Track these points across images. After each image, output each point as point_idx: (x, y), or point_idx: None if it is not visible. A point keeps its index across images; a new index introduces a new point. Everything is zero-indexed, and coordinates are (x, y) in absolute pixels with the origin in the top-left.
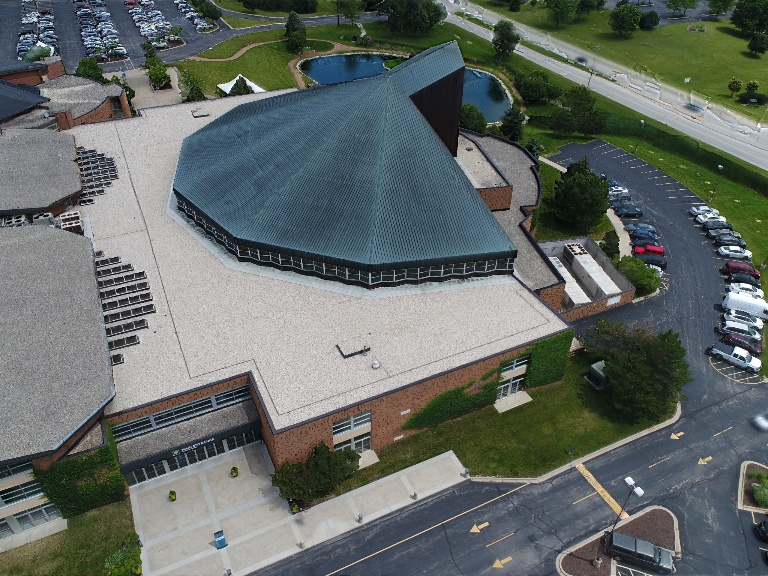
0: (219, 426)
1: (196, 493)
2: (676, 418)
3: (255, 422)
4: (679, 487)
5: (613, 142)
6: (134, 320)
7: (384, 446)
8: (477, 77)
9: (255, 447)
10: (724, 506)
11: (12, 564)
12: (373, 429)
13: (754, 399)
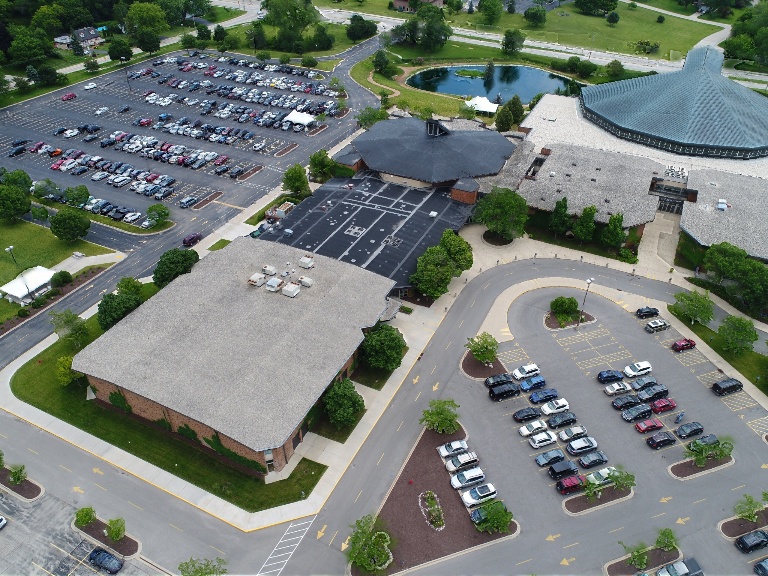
0: None
1: None
2: None
3: None
4: None
5: None
6: None
7: None
8: (515, 70)
9: None
10: None
11: None
12: None
13: None
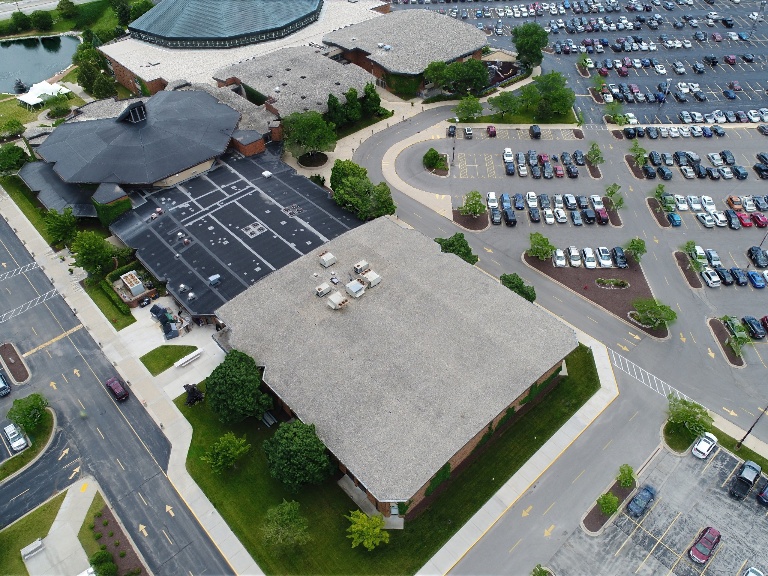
0: None
1: None
2: None
3: None
4: None
5: (132, 4)
6: None
7: None
8: None
9: None
10: None
11: None
12: None
13: None
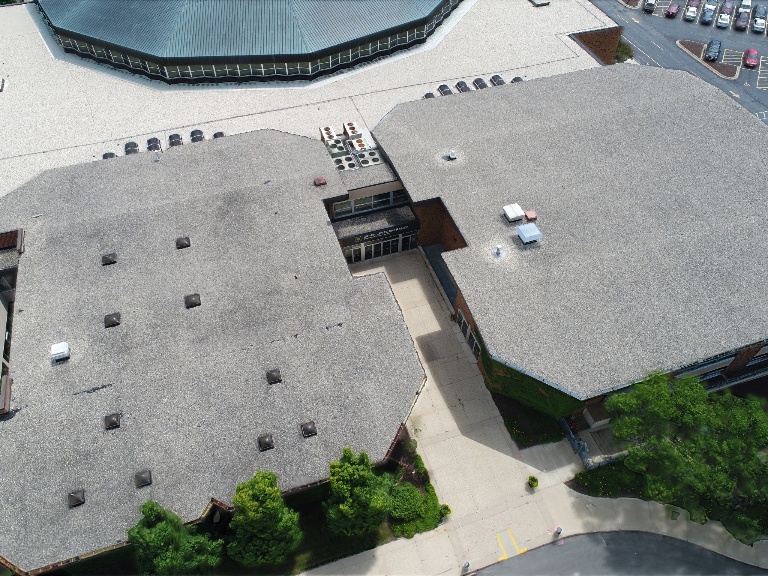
0: None
1: None
2: None
3: None
4: None
5: None
6: None
7: None
8: None
9: None
10: None
11: None
12: None
13: None
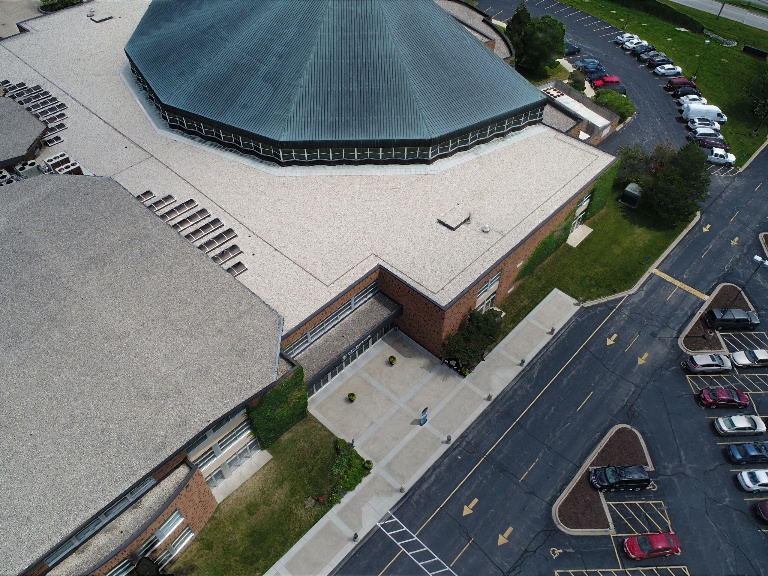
0: (367, 323)
1: (368, 389)
2: (699, 215)
3: (399, 310)
4: (729, 265)
5: None
6: (222, 249)
7: (502, 301)
8: None
9: (392, 335)
10: (764, 270)
11: (244, 503)
12: (499, 287)
13: (741, 186)
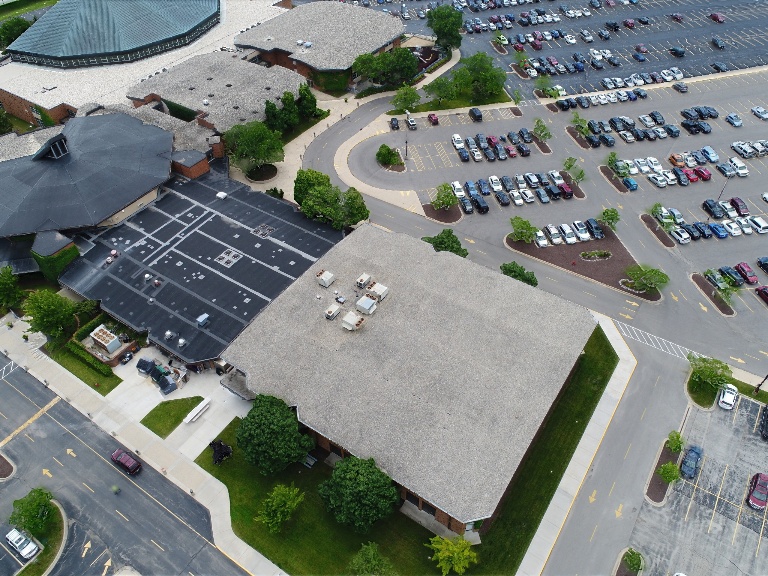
0: None
1: None
2: None
3: None
4: None
5: None
6: None
7: None
8: None
9: None
10: None
11: None
12: None
13: None
